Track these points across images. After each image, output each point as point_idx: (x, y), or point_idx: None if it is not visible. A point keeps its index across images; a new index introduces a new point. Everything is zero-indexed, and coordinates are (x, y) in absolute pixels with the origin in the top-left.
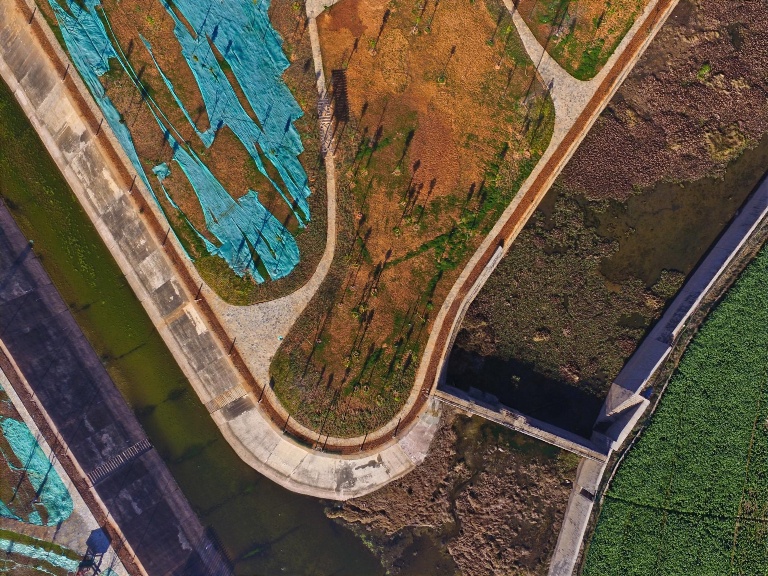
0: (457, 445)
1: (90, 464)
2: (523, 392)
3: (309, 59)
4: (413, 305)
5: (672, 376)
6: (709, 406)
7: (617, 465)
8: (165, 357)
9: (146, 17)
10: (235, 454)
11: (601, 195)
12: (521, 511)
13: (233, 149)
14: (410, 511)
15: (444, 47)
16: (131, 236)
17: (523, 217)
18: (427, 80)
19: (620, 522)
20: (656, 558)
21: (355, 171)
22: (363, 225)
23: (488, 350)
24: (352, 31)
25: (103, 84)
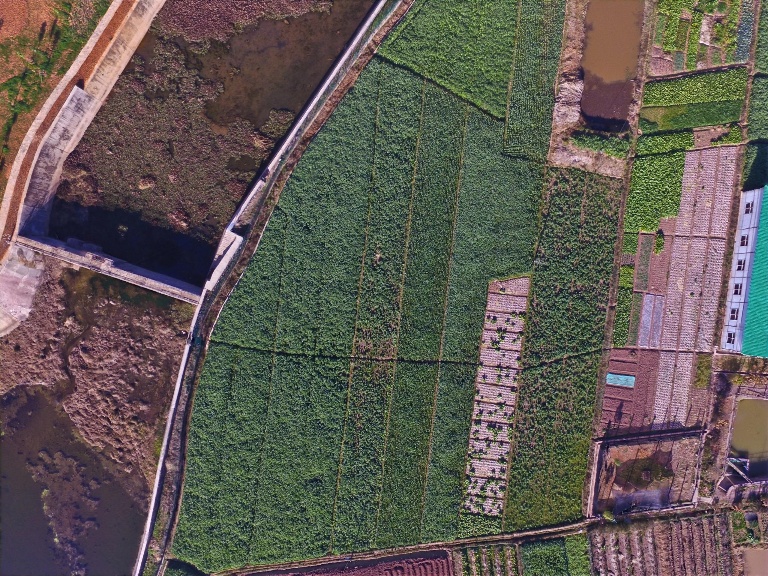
0: (66, 300)
1: None
2: (132, 242)
3: None
4: None
5: (272, 213)
6: (311, 242)
7: (221, 308)
8: None
9: None
10: None
11: (201, 36)
12: (136, 365)
13: None
14: (20, 369)
15: None
16: None
17: (103, 56)
18: None
19: (224, 366)
20: (266, 402)
21: None
22: None
23: (90, 200)
24: None
25: None
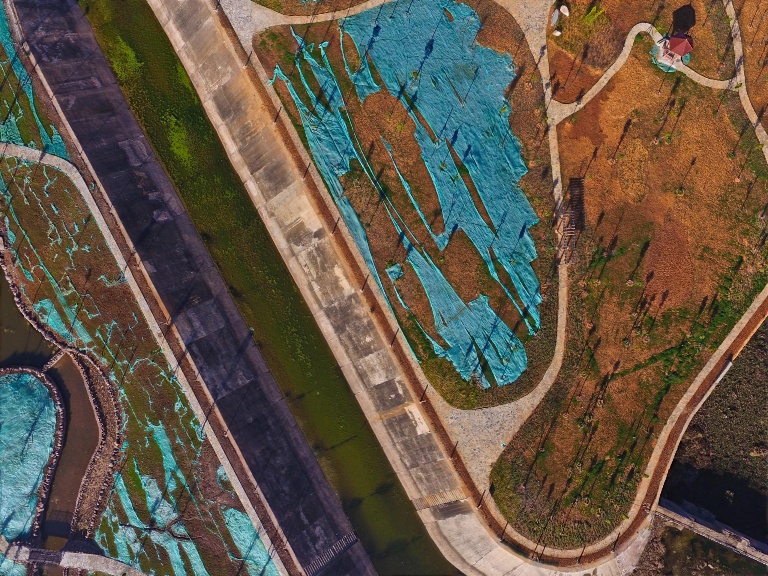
0: (665, 558)
1: (306, 558)
2: (736, 508)
3: (548, 166)
4: (638, 418)
5: None
6: None
7: None
8: (375, 451)
9: (388, 119)
10: (439, 552)
11: None
12: None
13: (467, 253)
14: None
15: (684, 158)
16: (356, 332)
17: (753, 332)
18: (665, 191)
19: None
20: None
21: (588, 280)
22: (593, 335)
23: (703, 463)
24: (592, 140)
25: (342, 184)
